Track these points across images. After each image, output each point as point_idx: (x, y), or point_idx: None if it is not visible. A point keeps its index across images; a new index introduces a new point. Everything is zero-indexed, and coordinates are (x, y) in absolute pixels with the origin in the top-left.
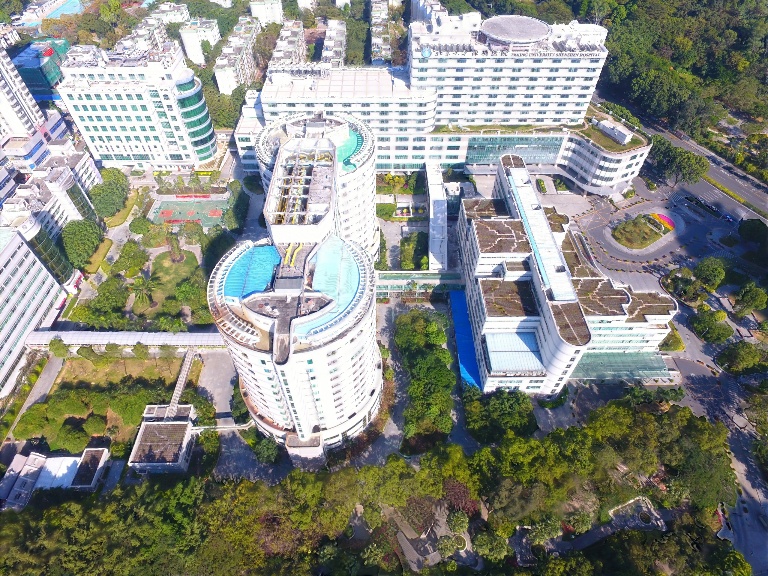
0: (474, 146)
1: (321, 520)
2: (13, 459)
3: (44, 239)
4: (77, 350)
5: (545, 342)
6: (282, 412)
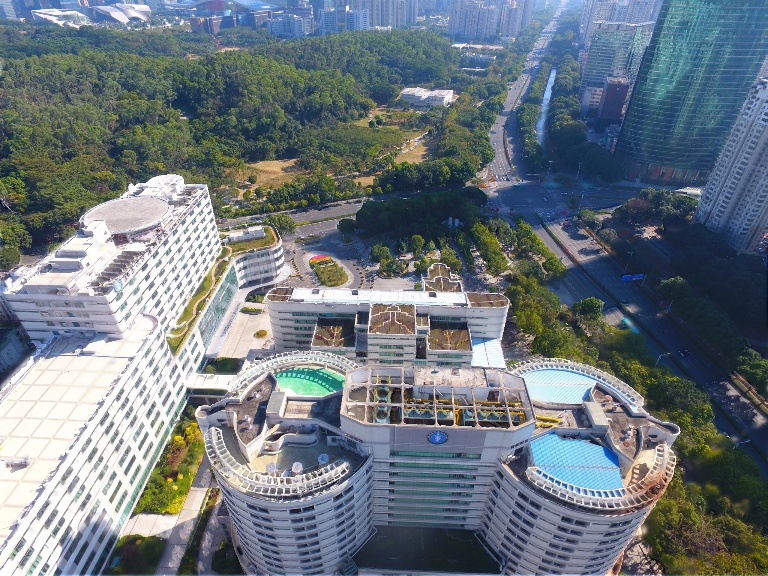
0: (203, 330)
1: None
2: None
3: None
4: None
5: (487, 327)
6: None
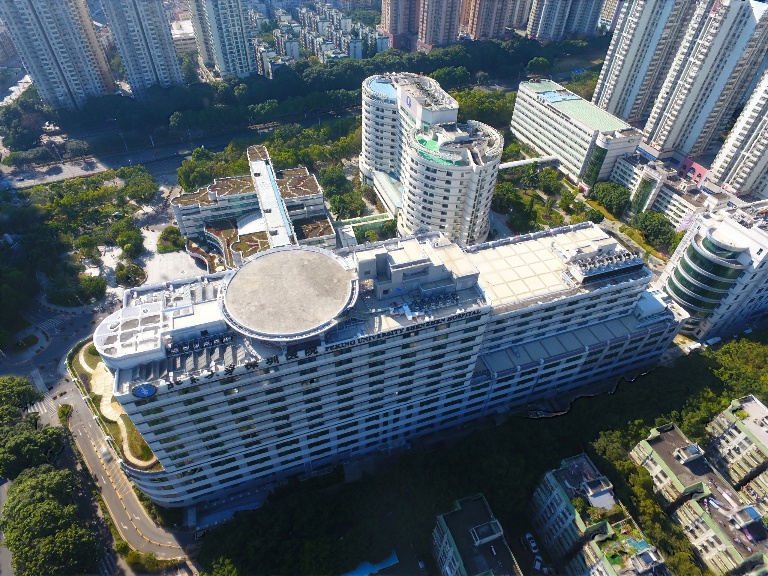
0: None
1: None
2: None
3: (598, 153)
4: None
5: None
6: None
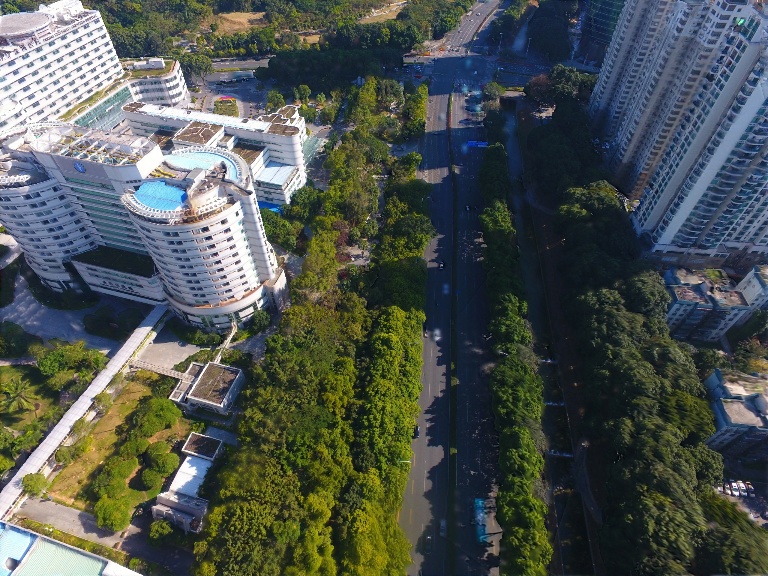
0: None
1: (328, 278)
2: (155, 511)
3: None
4: (56, 458)
5: (283, 153)
6: (253, 268)
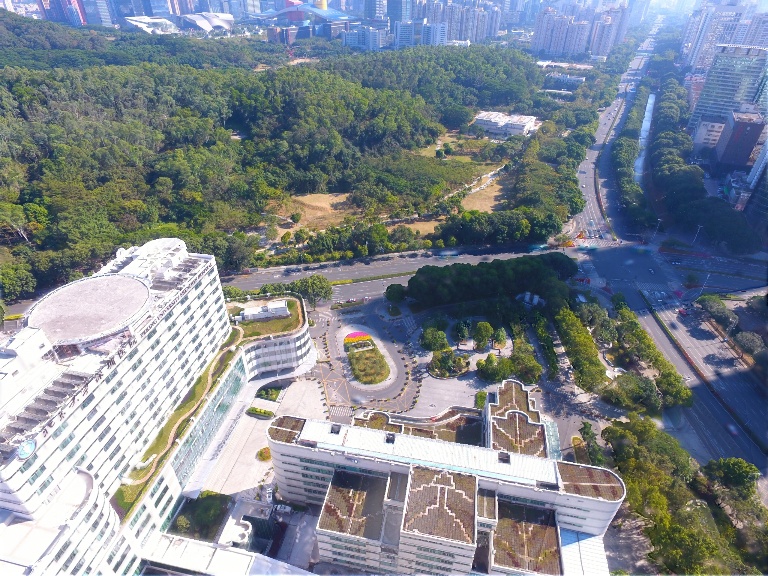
0: (180, 463)
1: None
2: None
3: None
4: None
5: (586, 520)
6: None
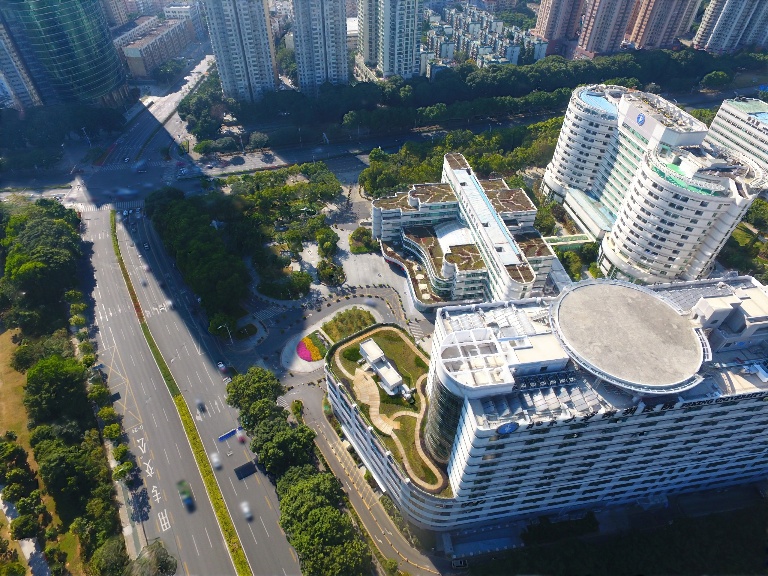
0: None
1: None
2: None
3: None
4: None
5: None
6: None
